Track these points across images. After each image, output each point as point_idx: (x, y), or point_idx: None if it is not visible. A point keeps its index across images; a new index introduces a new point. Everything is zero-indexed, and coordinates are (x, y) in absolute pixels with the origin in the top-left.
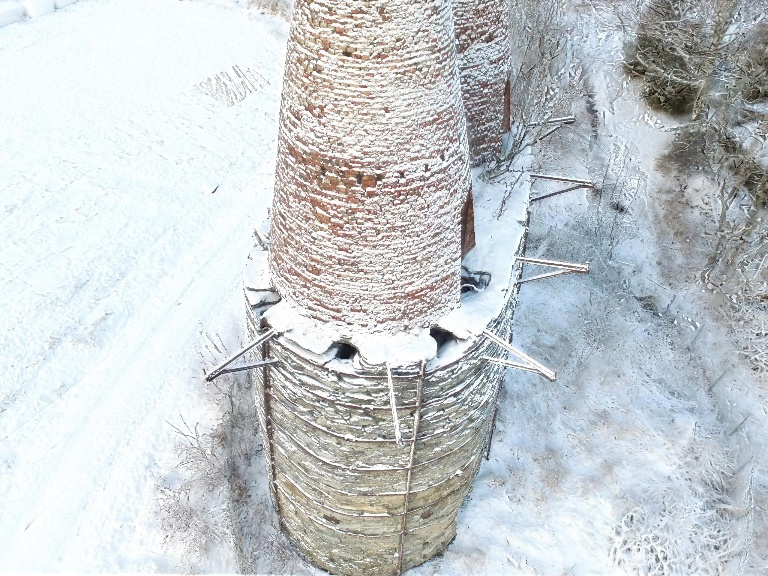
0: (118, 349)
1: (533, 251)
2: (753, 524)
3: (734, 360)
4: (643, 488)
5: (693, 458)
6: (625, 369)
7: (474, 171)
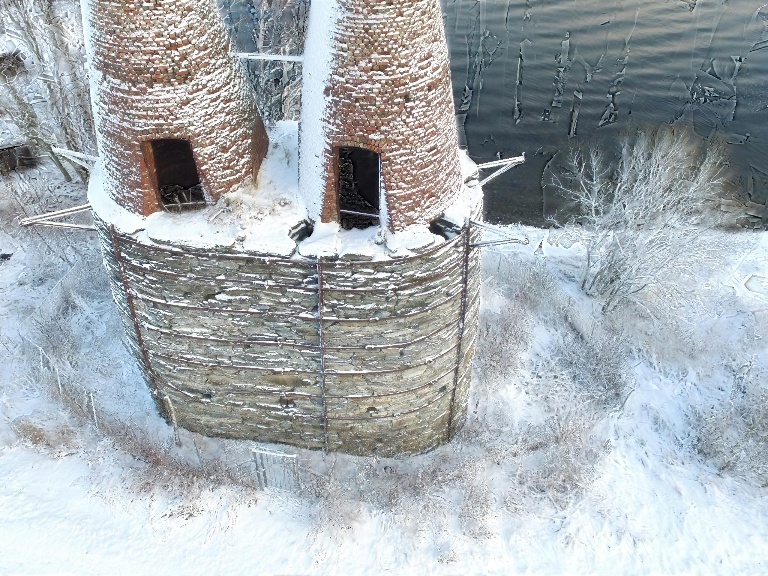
0: None
1: (76, 313)
2: None
3: None
4: None
5: None
6: None
7: None
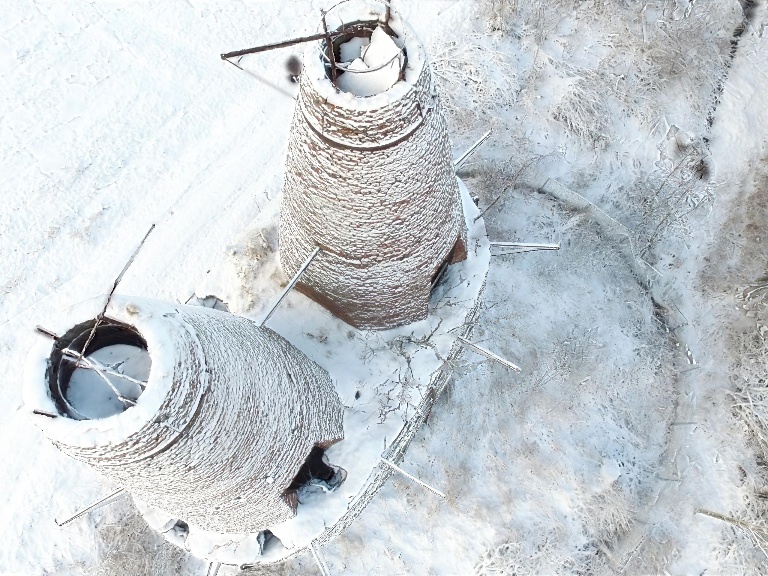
0: (109, 252)
1: (564, 218)
2: (628, 567)
3: (718, 399)
4: (535, 521)
5: (598, 507)
6: (585, 395)
7: (386, 333)
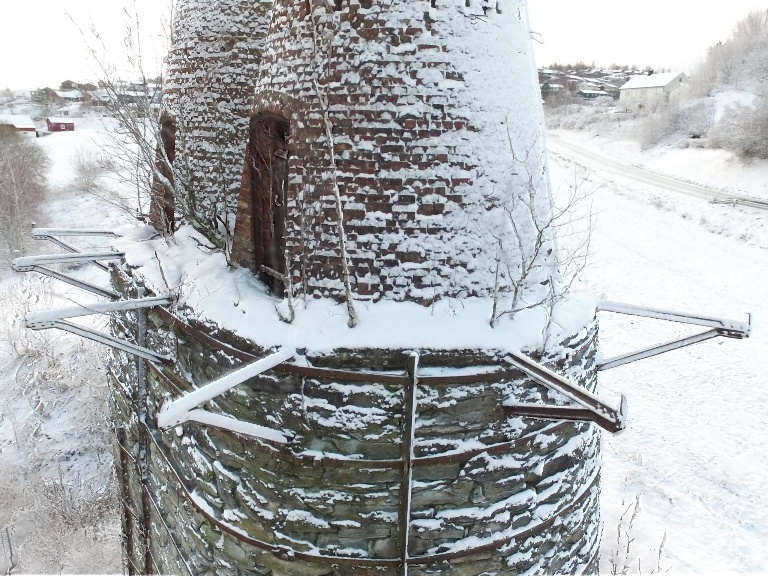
0: (608, 495)
1: None
2: None
3: None
4: None
5: None
6: None
7: None
